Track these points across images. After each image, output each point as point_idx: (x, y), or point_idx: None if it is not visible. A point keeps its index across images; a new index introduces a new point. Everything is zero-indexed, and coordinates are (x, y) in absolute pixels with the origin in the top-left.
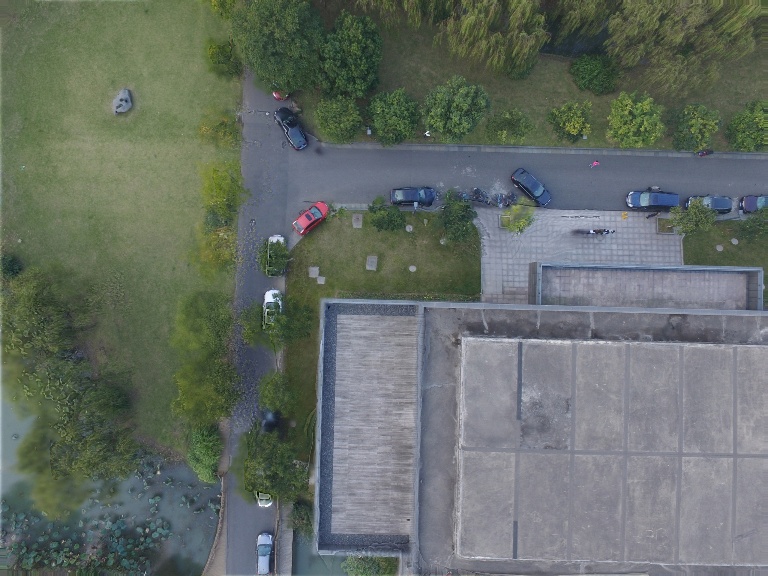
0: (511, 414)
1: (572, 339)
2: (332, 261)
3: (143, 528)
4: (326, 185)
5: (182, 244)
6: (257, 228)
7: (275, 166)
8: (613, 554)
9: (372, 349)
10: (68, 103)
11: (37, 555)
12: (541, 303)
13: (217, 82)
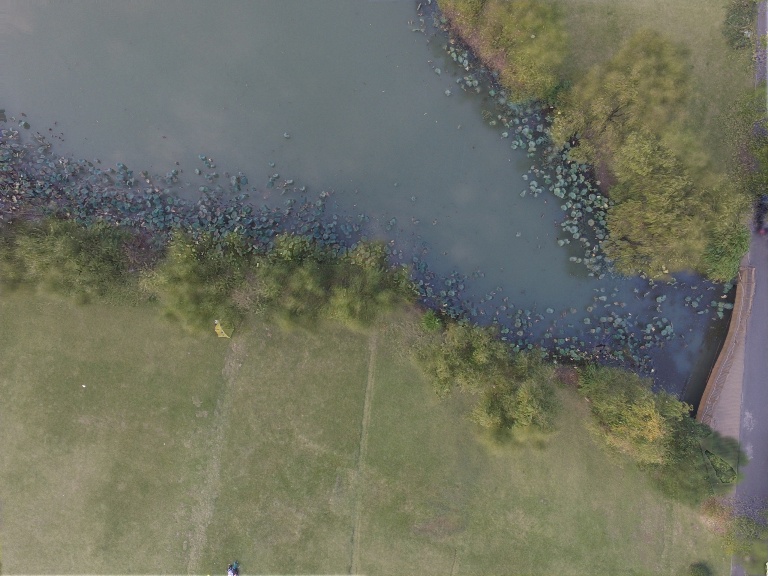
0: None
1: None
2: None
3: None
4: None
5: (701, 43)
6: None
7: None
8: None
9: None
10: None
11: (545, 351)
12: None
13: None
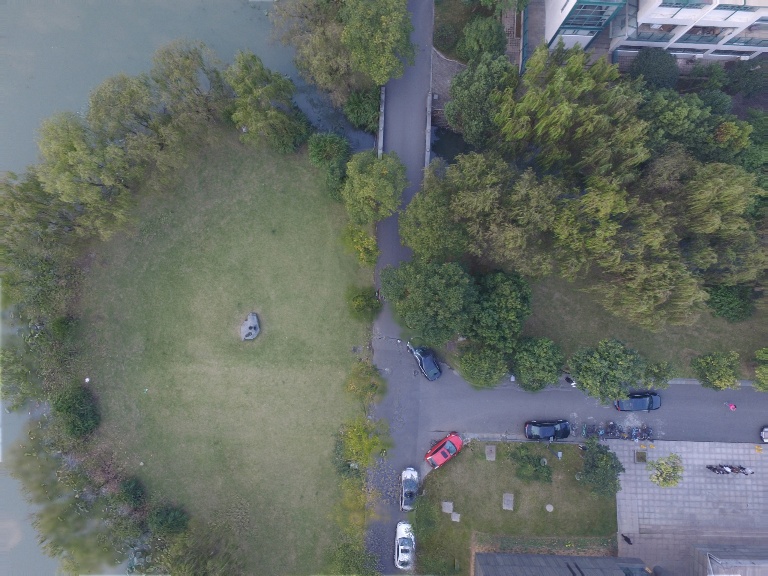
0: None
1: None
2: (467, 497)
3: None
4: (458, 414)
5: (310, 472)
6: (388, 459)
7: (406, 394)
8: None
9: None
10: (193, 325)
11: None
12: None
13: (347, 306)
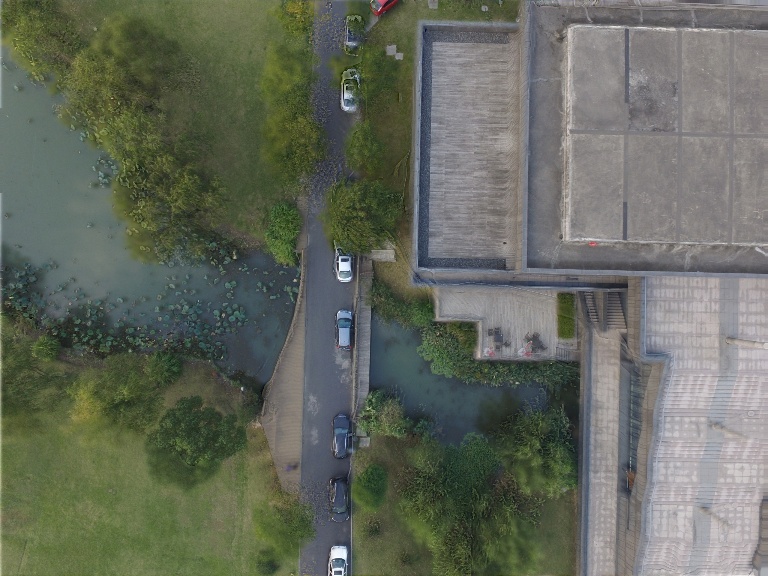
0: (619, 98)
1: (677, 28)
2: (410, 38)
3: (220, 312)
4: None
5: (258, 28)
6: (334, 10)
7: None
8: (721, 235)
9: (467, 76)
10: None
11: (113, 340)
12: (642, 5)
13: None
